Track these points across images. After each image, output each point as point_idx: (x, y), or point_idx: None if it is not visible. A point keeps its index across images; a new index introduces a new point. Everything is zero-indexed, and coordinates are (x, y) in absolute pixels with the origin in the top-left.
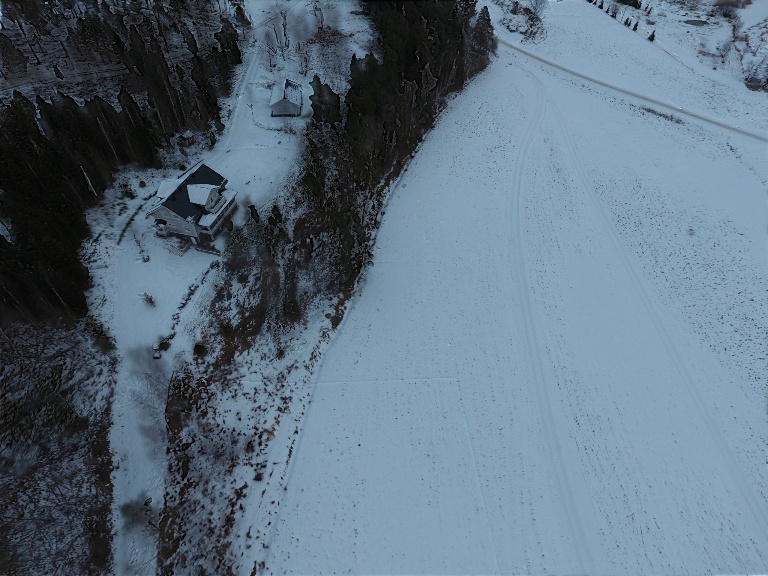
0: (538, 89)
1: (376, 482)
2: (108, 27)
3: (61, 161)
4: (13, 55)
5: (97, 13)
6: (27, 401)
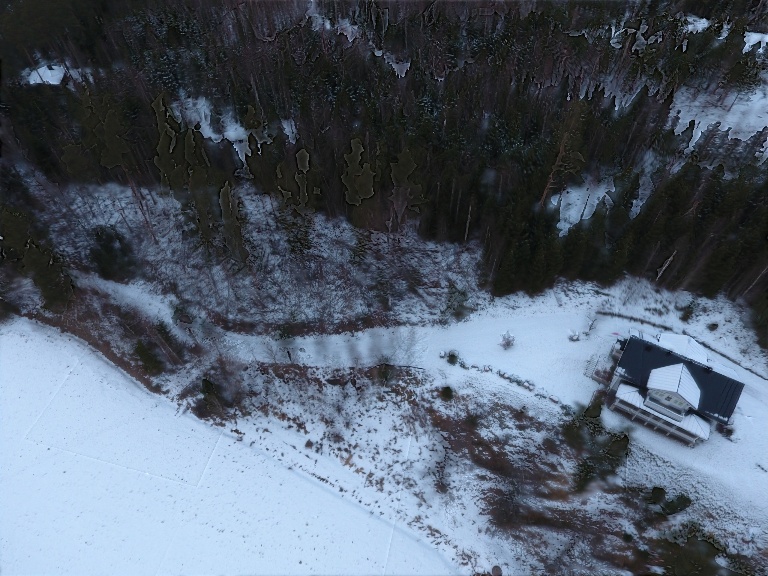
0: None
1: (254, 570)
2: None
3: None
4: None
5: None
6: (410, 271)
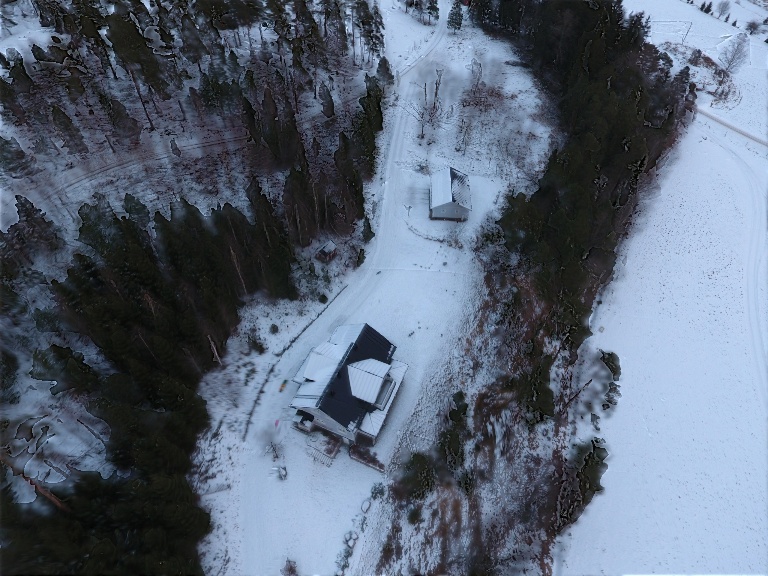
0: (749, 178)
1: None
2: (236, 87)
3: (181, 318)
4: (126, 125)
5: (223, 66)
6: None
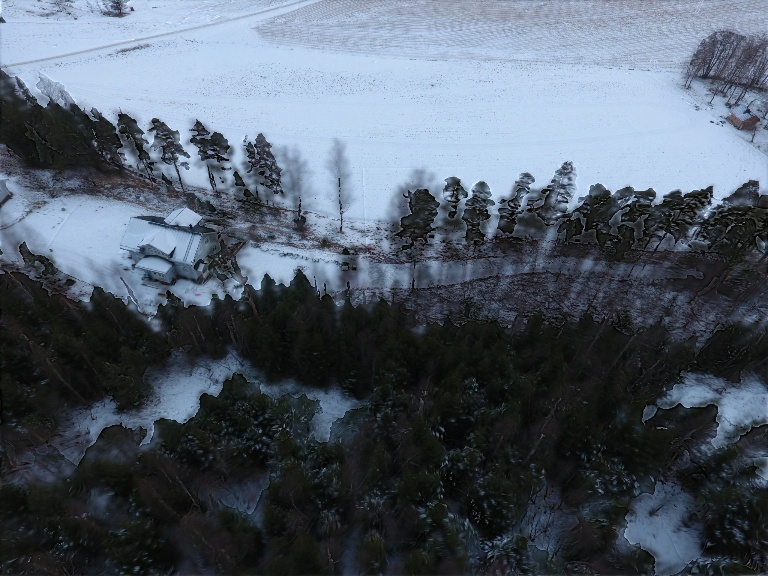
0: None
1: None
2: None
3: None
4: None
5: None
6: None
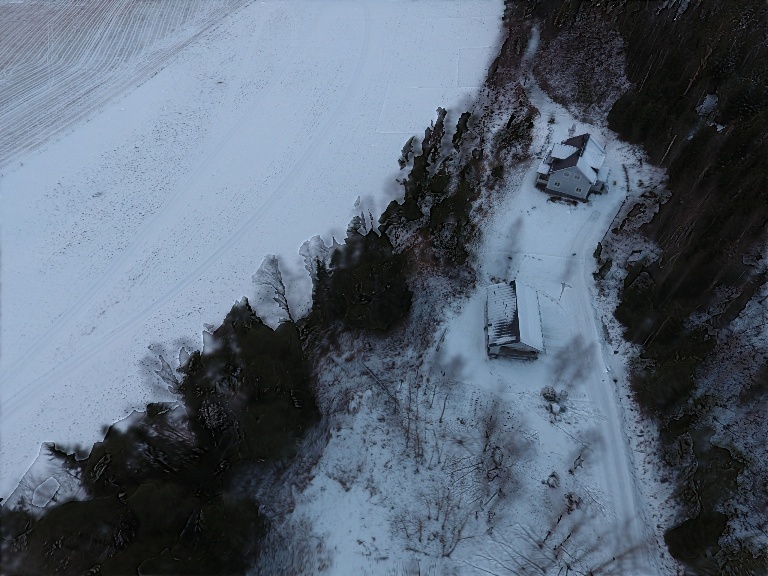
0: None
1: None
2: None
3: (706, 149)
4: None
5: None
6: None
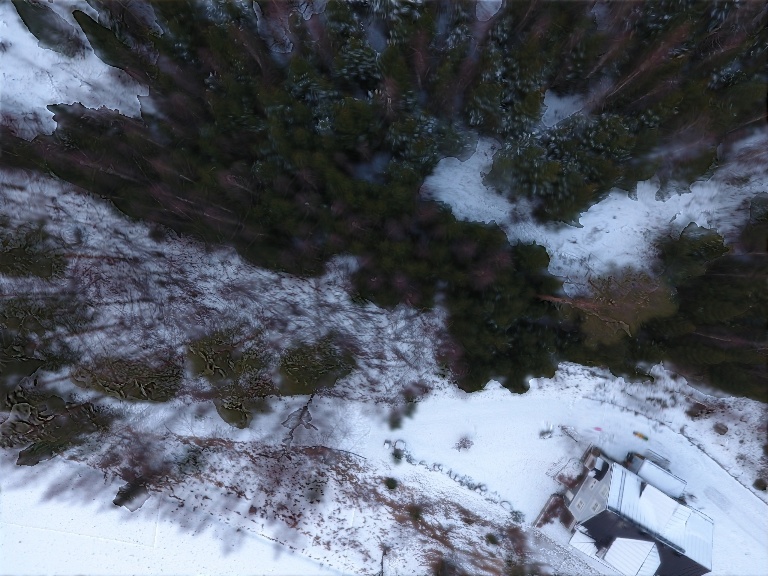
0: None
1: None
2: None
3: (751, 367)
4: None
5: None
6: (344, 336)
